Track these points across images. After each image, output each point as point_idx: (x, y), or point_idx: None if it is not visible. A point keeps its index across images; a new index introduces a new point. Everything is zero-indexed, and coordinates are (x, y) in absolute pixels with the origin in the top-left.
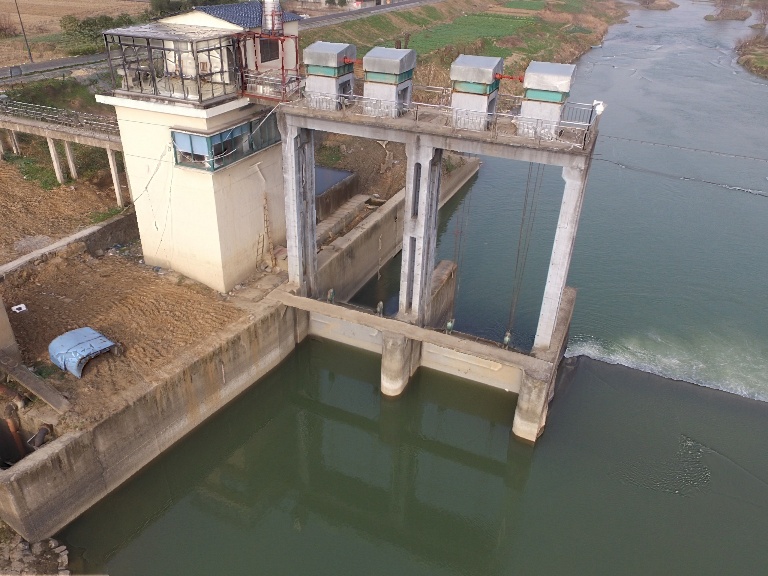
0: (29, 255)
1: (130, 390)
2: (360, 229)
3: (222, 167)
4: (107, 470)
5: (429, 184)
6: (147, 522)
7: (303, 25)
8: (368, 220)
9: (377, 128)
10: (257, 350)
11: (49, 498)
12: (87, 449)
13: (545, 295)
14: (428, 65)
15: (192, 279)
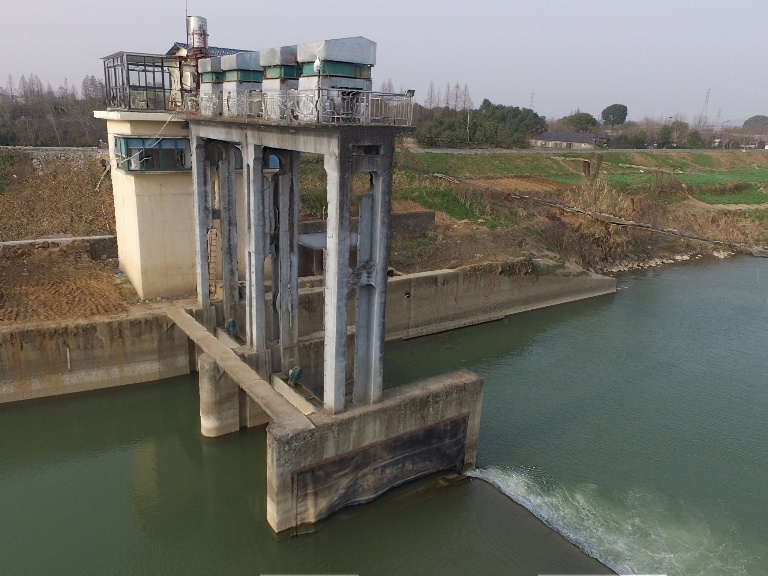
0: (35, 240)
1: None
2: None
3: (141, 171)
4: None
5: (261, 190)
6: None
7: (511, 149)
8: None
9: (227, 128)
10: (122, 352)
11: None
12: None
13: (326, 332)
14: (597, 180)
15: (132, 284)
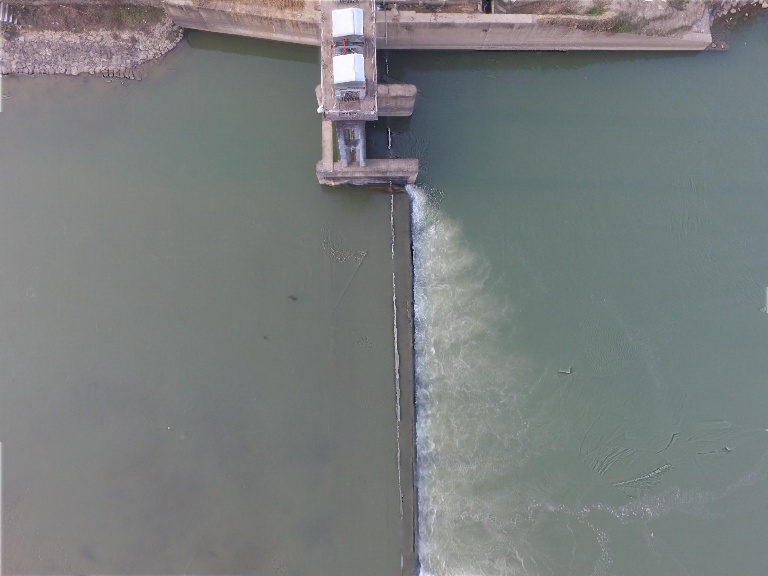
0: None
1: (222, 3)
2: (433, 18)
3: None
4: (207, 24)
5: None
6: (233, 51)
7: None
8: (451, 16)
9: None
10: (299, 32)
11: (180, 16)
12: (196, 12)
13: None
14: None
15: None
